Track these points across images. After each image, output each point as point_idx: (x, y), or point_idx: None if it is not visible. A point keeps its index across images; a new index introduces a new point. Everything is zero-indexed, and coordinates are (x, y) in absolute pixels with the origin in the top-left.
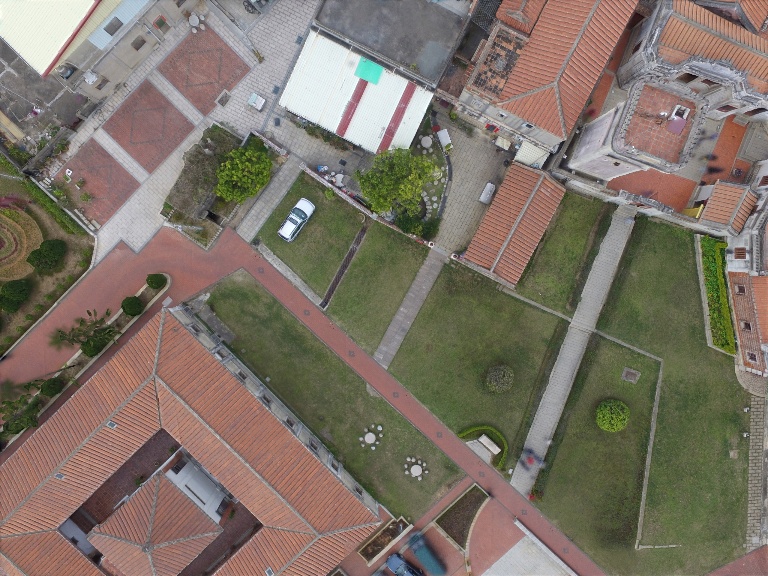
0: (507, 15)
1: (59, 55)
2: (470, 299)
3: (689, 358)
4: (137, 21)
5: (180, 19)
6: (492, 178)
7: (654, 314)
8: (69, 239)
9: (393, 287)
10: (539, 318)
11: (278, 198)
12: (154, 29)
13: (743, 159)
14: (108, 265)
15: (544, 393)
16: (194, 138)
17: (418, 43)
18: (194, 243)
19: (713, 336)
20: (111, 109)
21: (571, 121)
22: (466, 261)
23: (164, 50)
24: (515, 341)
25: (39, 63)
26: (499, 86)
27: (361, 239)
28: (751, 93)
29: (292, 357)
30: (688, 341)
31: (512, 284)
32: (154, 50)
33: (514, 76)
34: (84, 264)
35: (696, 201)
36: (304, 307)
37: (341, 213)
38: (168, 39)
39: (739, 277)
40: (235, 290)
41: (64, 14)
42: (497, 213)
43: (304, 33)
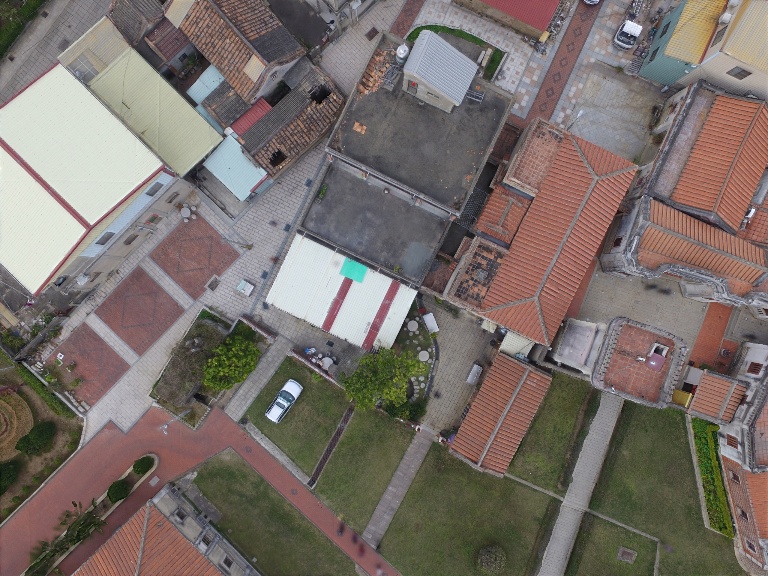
0: (487, 227)
1: (51, 276)
2: (460, 477)
3: (686, 539)
4: (129, 227)
5: (172, 209)
6: (479, 357)
7: (648, 493)
8: (59, 419)
9: (381, 465)
10: (530, 496)
11: (266, 378)
12: (146, 225)
13: (731, 339)
14: (96, 445)
15: (538, 574)
16: (184, 321)
17: (402, 244)
18: (182, 423)
19: (710, 518)
20: (104, 295)
21: (553, 328)
22: (453, 452)
23: (156, 238)
24: (506, 520)
25: (31, 283)
26: (481, 294)
27: (349, 418)
28: (733, 297)
29: (279, 536)
30: (684, 521)
31: (501, 473)
32: (147, 239)
33: (495, 285)
34: (72, 446)
35: (685, 382)
36: (292, 486)
37: (329, 392)
38: (160, 228)
39: (733, 465)
40: (222, 469)
41: (57, 240)
42: (483, 404)
43: (292, 221)
